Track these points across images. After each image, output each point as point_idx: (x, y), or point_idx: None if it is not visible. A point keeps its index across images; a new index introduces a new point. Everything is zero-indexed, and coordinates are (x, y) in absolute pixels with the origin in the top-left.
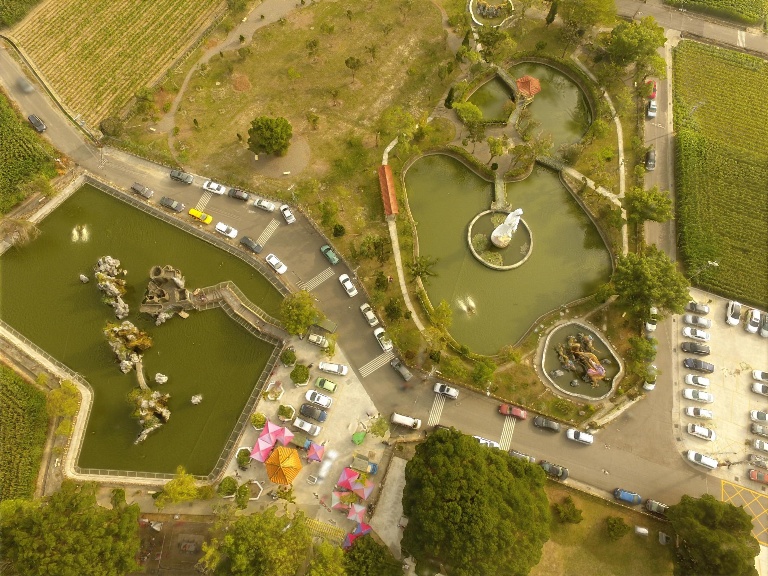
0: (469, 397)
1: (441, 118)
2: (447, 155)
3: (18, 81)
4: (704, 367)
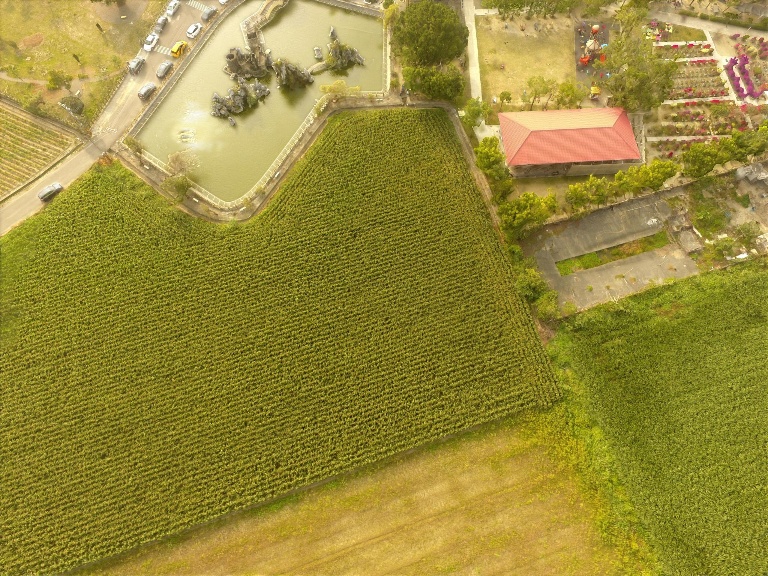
0: None
1: None
2: None
3: None
4: None
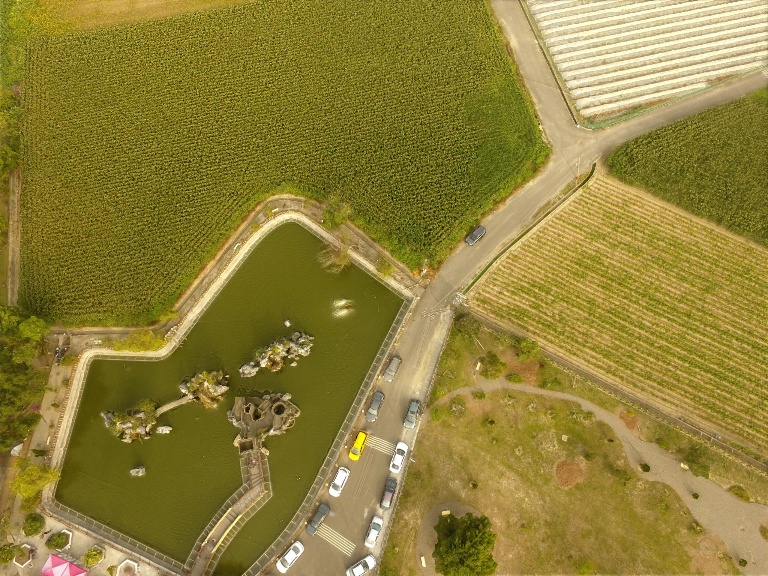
0: None
1: None
2: None
3: (533, 200)
4: None
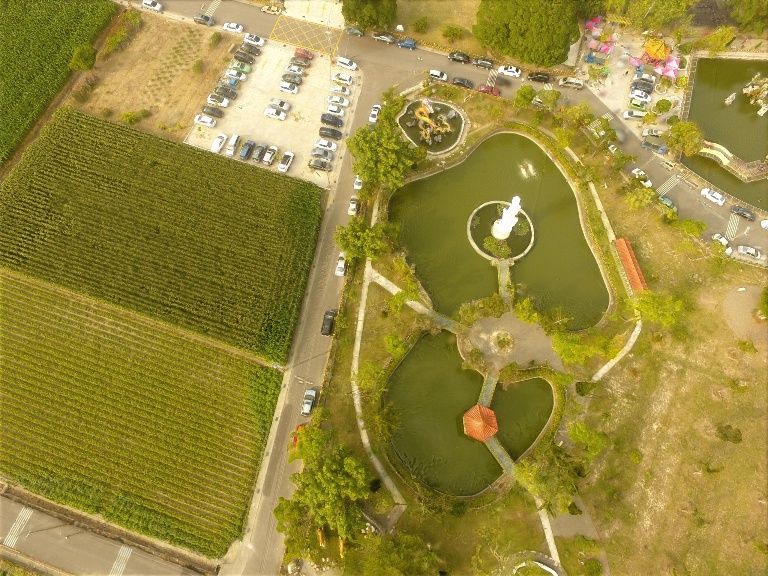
0: None
1: (583, 380)
2: (566, 330)
3: None
4: (331, 116)
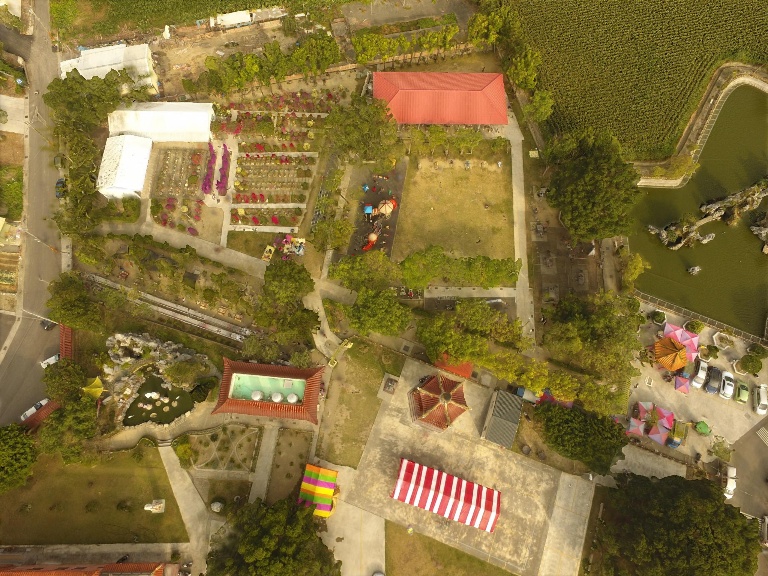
0: (767, 561)
1: None
2: None
3: None
4: None
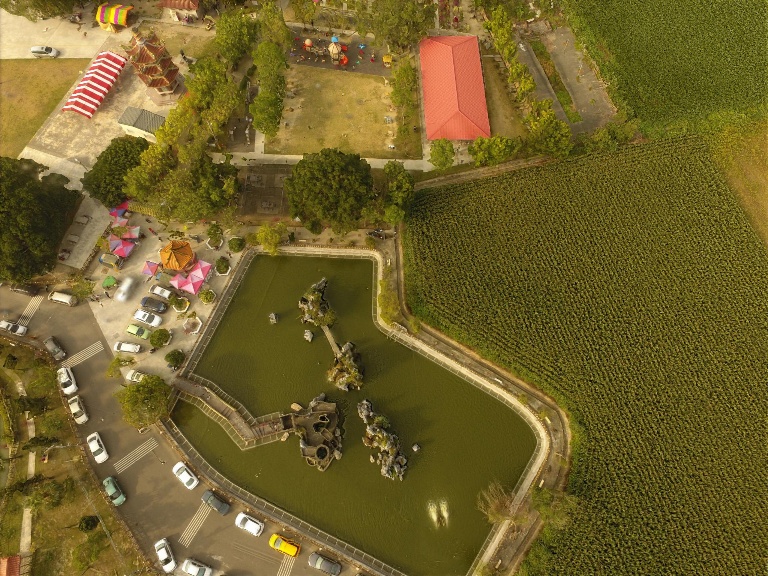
0: None
1: None
2: None
3: None
4: None
